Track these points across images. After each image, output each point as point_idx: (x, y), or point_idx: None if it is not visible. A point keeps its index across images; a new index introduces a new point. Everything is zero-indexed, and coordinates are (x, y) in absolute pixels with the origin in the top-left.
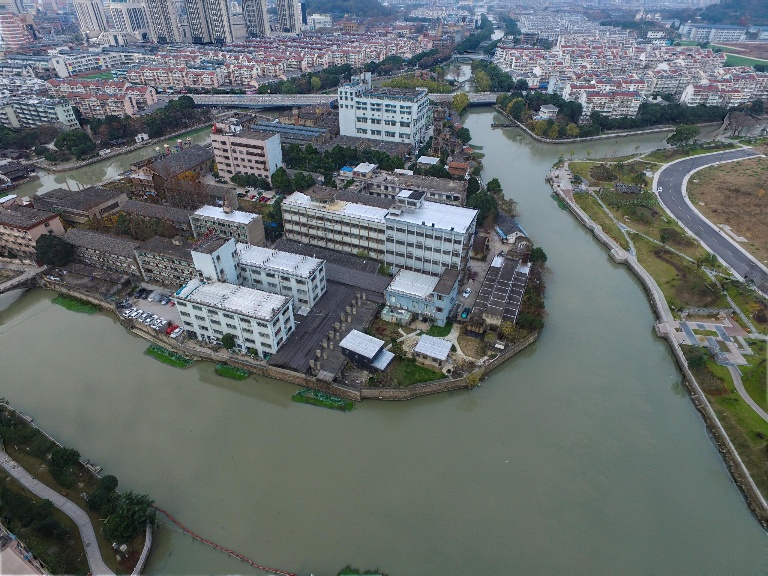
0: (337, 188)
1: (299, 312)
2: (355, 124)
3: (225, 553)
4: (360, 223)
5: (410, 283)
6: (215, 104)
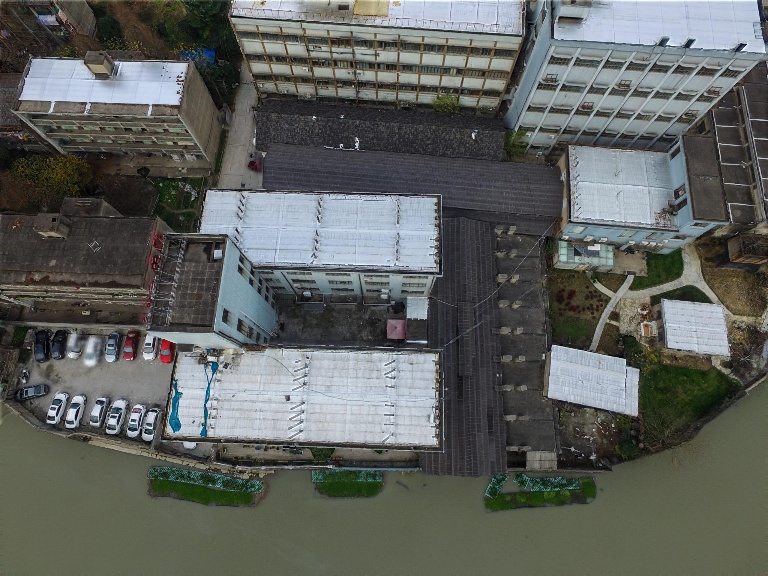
0: None
1: (410, 313)
2: None
3: None
4: (449, 41)
5: (609, 187)
6: None
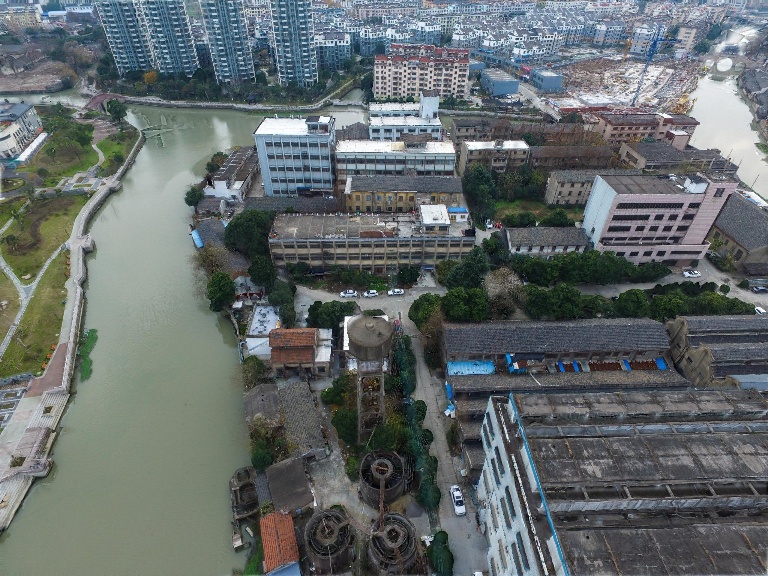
0: None
1: None
2: None
3: (341, 110)
4: None
5: None
6: None
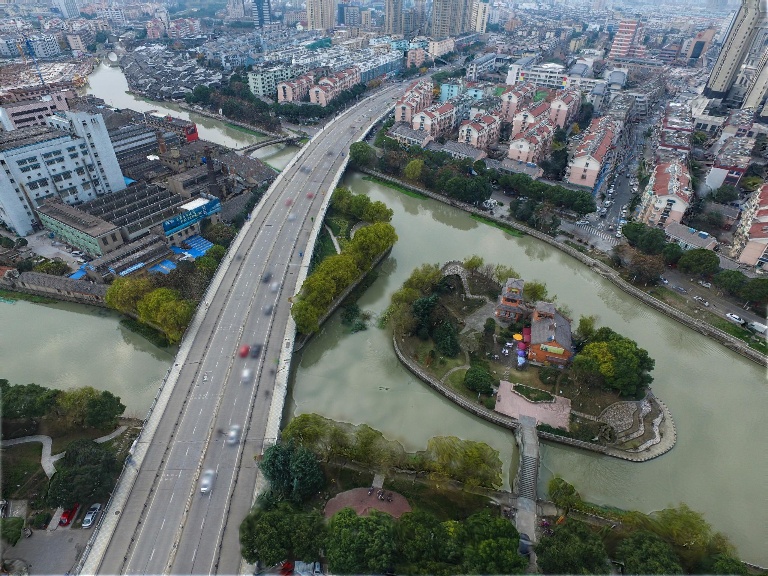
0: None
1: None
2: None
3: None
4: None
5: None
6: None
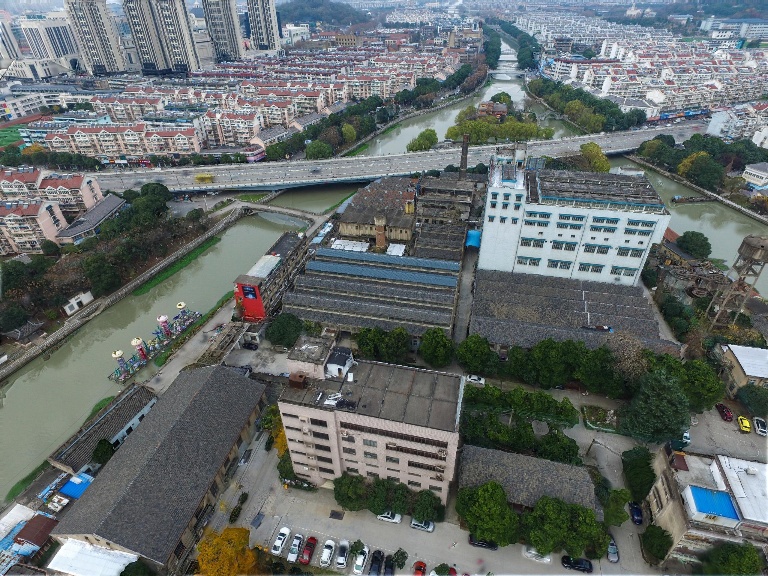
0: (671, 545)
1: None
2: (515, 250)
3: None
4: None
5: None
6: (204, 189)
